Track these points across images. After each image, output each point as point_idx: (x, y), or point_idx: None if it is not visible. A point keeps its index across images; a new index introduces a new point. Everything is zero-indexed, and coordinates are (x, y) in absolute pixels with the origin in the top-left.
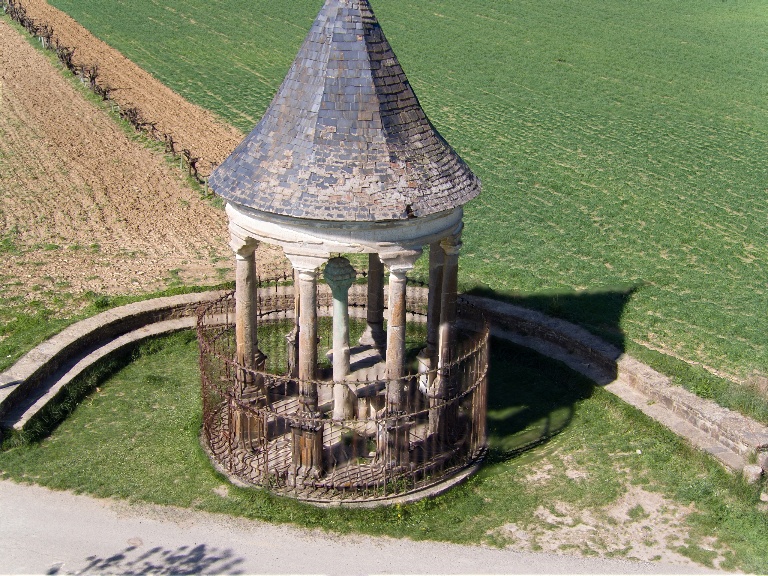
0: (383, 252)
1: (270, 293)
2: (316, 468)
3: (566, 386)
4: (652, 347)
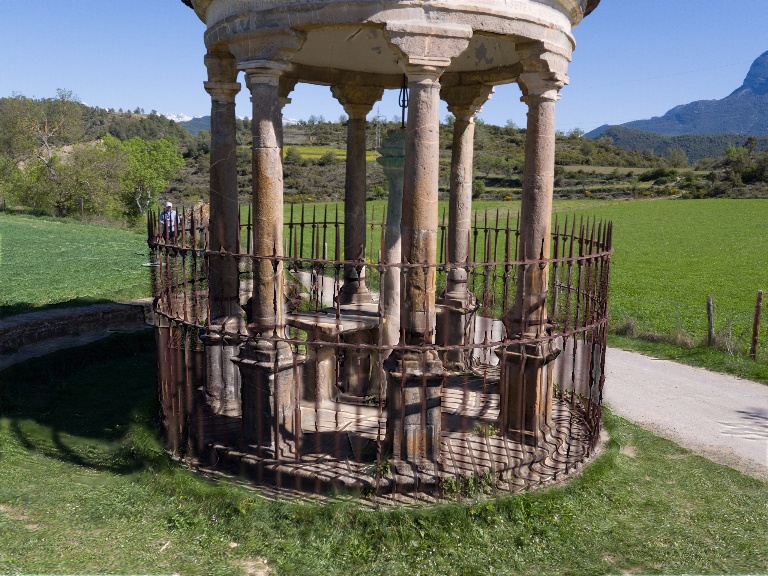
0: None
1: None
2: None
3: (146, 350)
4: None
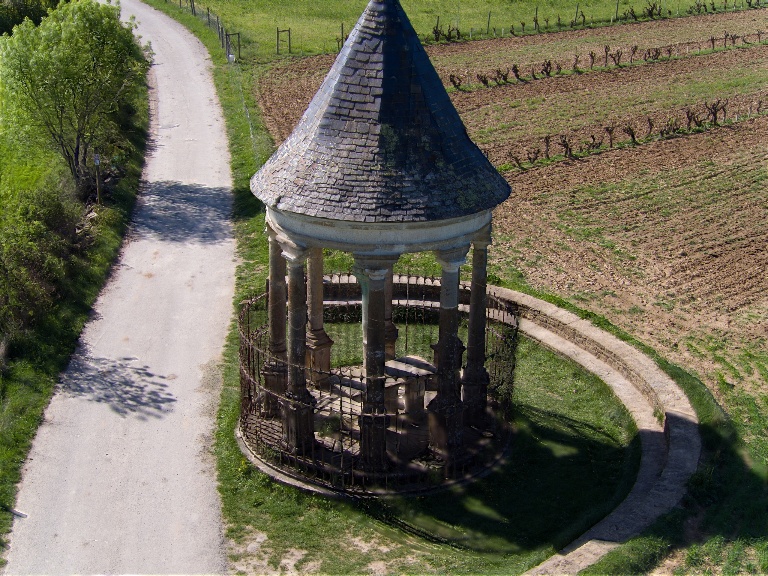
0: (279, 234)
1: (591, 334)
2: (266, 408)
3: None
4: (668, 568)
